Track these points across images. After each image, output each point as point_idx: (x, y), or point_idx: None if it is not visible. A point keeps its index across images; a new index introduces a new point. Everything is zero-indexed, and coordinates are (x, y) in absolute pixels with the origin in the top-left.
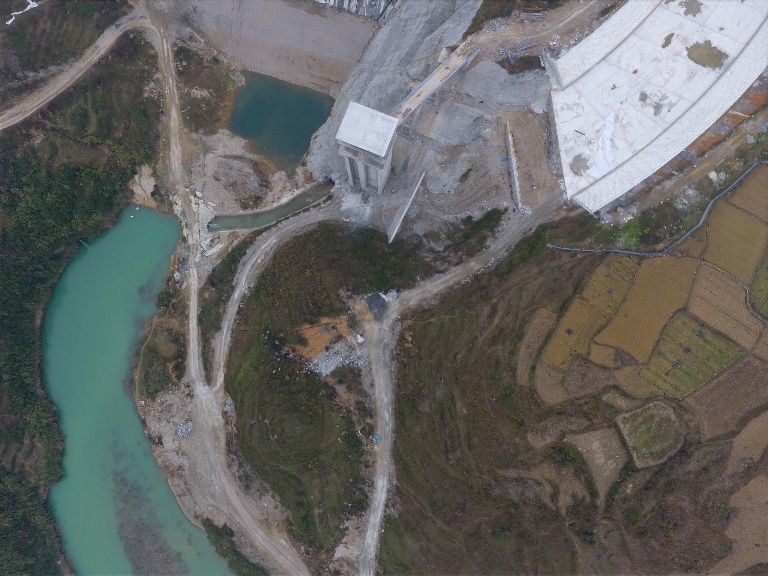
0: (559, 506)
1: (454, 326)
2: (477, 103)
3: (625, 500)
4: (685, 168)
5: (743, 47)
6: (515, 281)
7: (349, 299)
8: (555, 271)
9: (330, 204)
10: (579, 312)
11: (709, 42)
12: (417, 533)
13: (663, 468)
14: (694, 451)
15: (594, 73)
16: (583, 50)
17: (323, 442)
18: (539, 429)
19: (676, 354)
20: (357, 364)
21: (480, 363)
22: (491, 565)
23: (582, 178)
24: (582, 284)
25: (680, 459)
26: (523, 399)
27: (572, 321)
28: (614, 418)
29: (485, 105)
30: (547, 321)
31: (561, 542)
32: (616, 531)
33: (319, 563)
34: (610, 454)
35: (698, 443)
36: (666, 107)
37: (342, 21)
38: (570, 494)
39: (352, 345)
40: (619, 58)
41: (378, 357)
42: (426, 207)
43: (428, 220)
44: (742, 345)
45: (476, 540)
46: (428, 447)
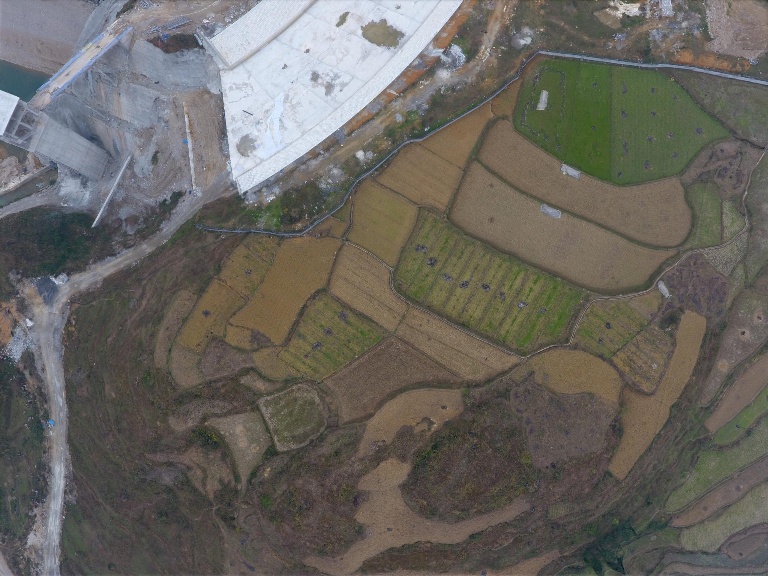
0: (207, 491)
1: (111, 309)
2: (153, 84)
3: (260, 484)
4: (331, 147)
5: (419, 26)
6: (162, 263)
7: (18, 282)
8: (199, 252)
9: (48, 189)
10: (217, 293)
11: (385, 21)
12: (93, 519)
13: (299, 451)
14: (327, 434)
15: (265, 52)
16: (242, 28)
17: (10, 428)
18: (181, 412)
19: (316, 336)
20: (31, 348)
21: (126, 346)
22: (157, 551)
23: (249, 159)
24: (219, 265)
25: (315, 442)
26: (160, 382)
27: (209, 302)
28: (256, 401)
29: (161, 86)
30: (188, 303)
31: (210, 527)
32: (254, 515)
33: (14, 551)
34: (253, 438)
35: (336, 426)
36: (338, 87)
37: (61, 4)
38: (218, 478)
39: (25, 329)
40: (291, 37)
41: (48, 341)
42: (132, 191)
43: (133, 204)
44: (384, 326)
45: (139, 526)
46: (92, 432)
